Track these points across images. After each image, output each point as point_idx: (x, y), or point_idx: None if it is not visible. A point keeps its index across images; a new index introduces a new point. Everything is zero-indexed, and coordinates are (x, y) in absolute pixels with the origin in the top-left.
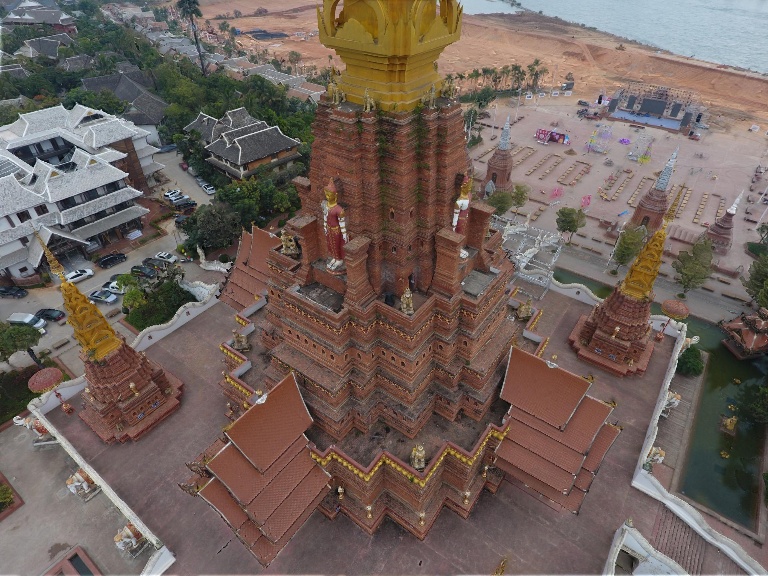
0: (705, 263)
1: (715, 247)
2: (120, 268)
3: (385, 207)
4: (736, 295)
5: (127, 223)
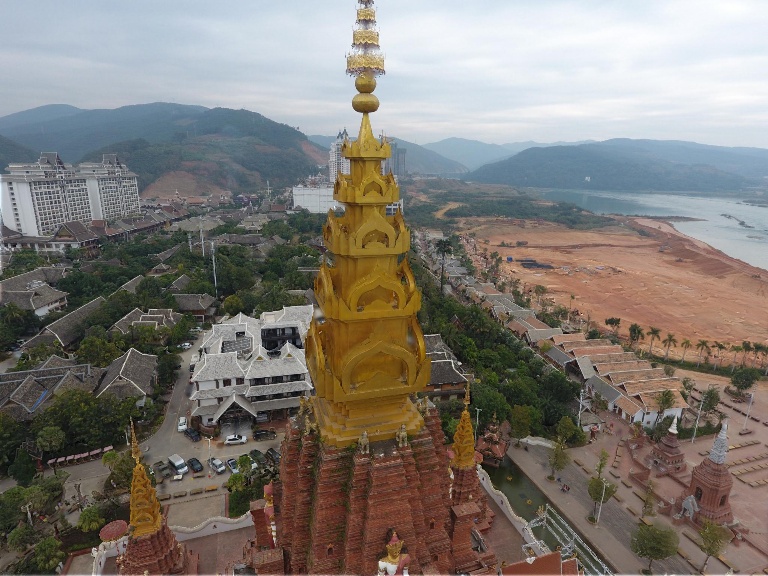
0: None
1: None
2: (265, 444)
3: (310, 530)
4: None
5: (294, 408)
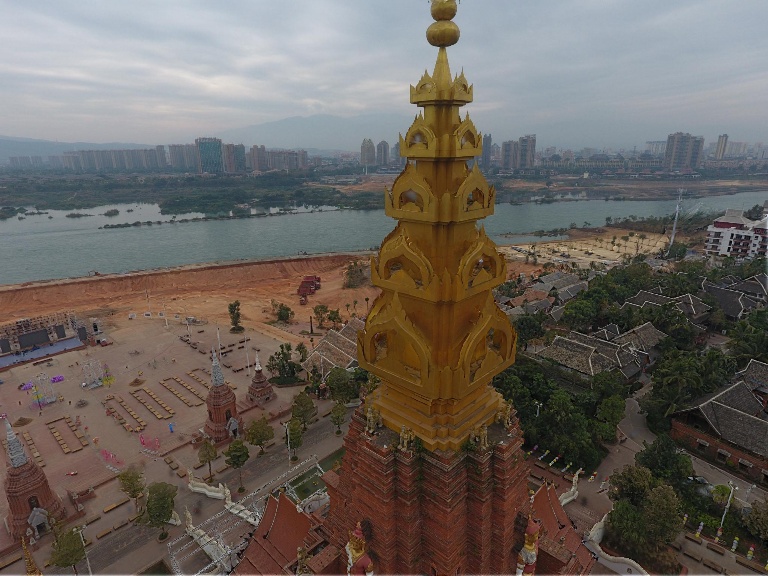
0: (312, 405)
1: (269, 397)
2: None
3: None
4: (328, 411)
5: None
